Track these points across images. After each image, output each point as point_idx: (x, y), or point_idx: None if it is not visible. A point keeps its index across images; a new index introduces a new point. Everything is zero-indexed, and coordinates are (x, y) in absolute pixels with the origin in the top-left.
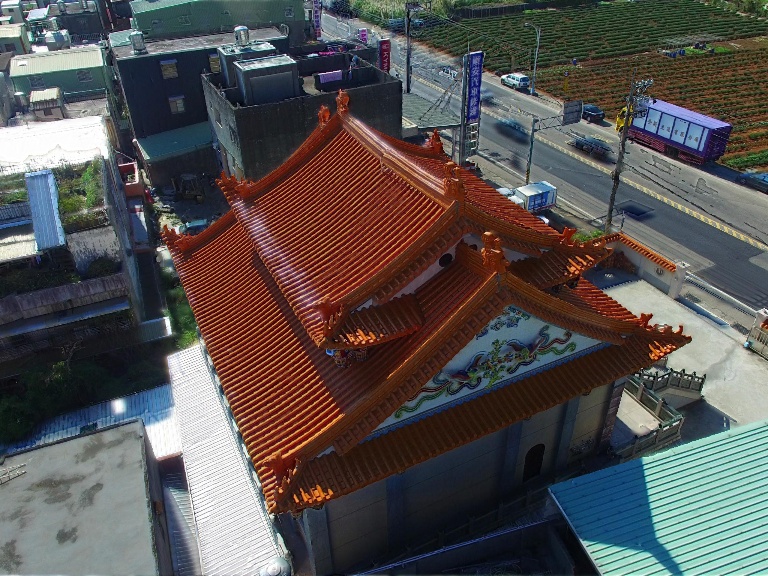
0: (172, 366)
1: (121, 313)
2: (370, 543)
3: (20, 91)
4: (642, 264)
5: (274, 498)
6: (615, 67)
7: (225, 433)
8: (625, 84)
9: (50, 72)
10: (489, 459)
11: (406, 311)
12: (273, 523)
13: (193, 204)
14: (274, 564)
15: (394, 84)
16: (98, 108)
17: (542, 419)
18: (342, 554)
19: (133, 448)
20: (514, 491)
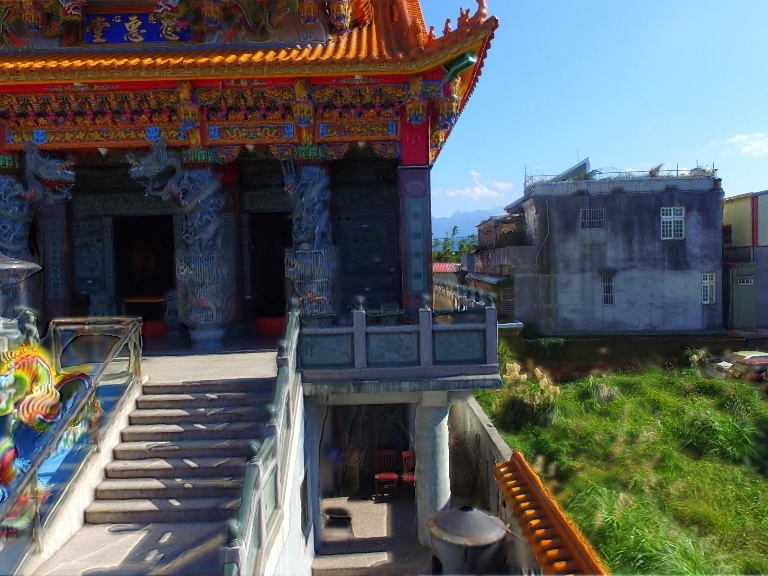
0: None
1: None
2: None
3: None
4: None
5: None
6: None
7: None
8: None
9: None
10: None
11: None
12: None
13: None
14: None
15: None
16: None
17: None
18: None
19: None
20: None
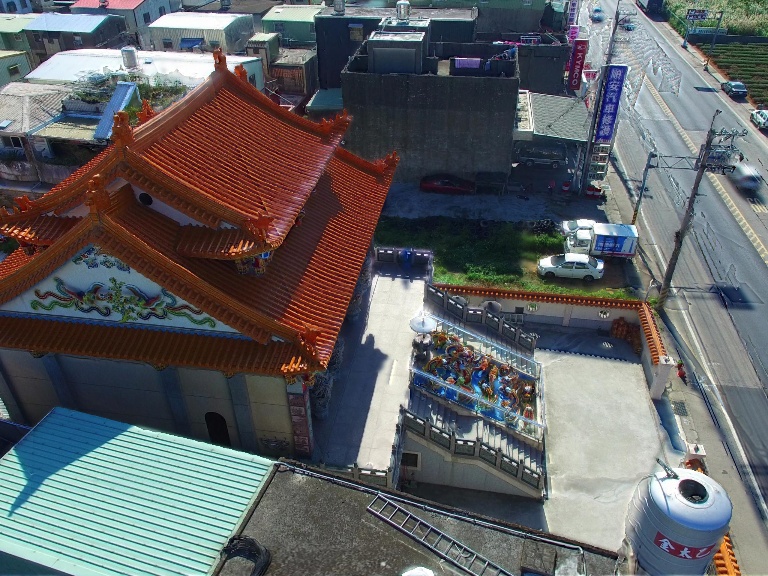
0: None
1: None
2: None
3: (267, 33)
4: (645, 346)
5: None
6: None
7: None
8: None
9: (292, 21)
10: (158, 399)
11: None
12: None
13: None
14: None
15: (510, 81)
16: (297, 56)
17: (209, 387)
18: (34, 412)
19: None
20: None
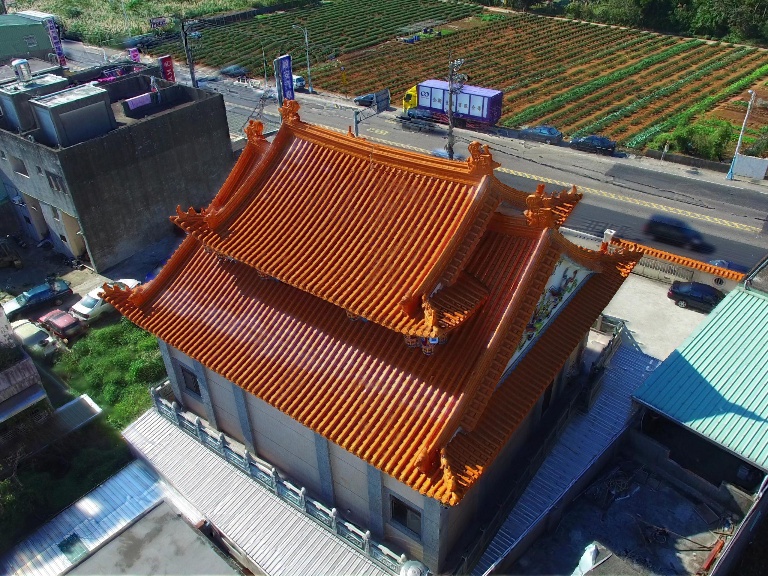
0: (134, 440)
1: (36, 405)
2: (465, 516)
3: None
4: None
5: (452, 489)
6: (369, 58)
7: (244, 482)
8: (387, 72)
9: None
10: None
11: (469, 286)
12: (369, 538)
13: (11, 272)
14: (411, 568)
15: (216, 98)
16: None
17: None
18: (450, 536)
19: (179, 530)
20: (545, 426)
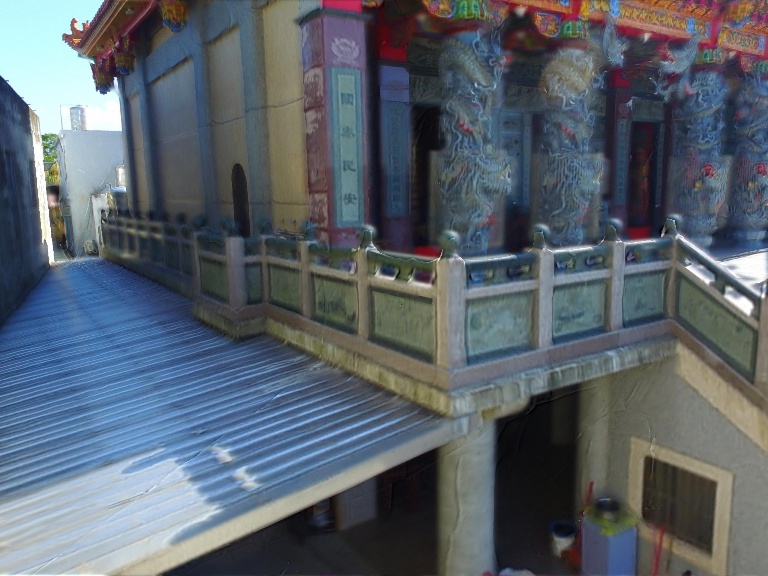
0: None
1: None
2: None
3: None
4: None
5: None
6: None
7: None
8: None
9: None
10: None
11: None
12: None
13: None
14: None
15: None
16: None
17: None
18: None
19: None
20: None
